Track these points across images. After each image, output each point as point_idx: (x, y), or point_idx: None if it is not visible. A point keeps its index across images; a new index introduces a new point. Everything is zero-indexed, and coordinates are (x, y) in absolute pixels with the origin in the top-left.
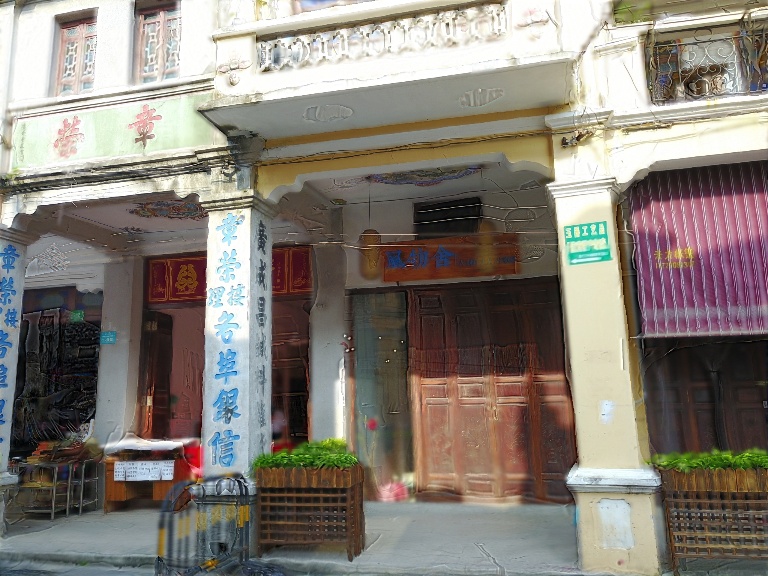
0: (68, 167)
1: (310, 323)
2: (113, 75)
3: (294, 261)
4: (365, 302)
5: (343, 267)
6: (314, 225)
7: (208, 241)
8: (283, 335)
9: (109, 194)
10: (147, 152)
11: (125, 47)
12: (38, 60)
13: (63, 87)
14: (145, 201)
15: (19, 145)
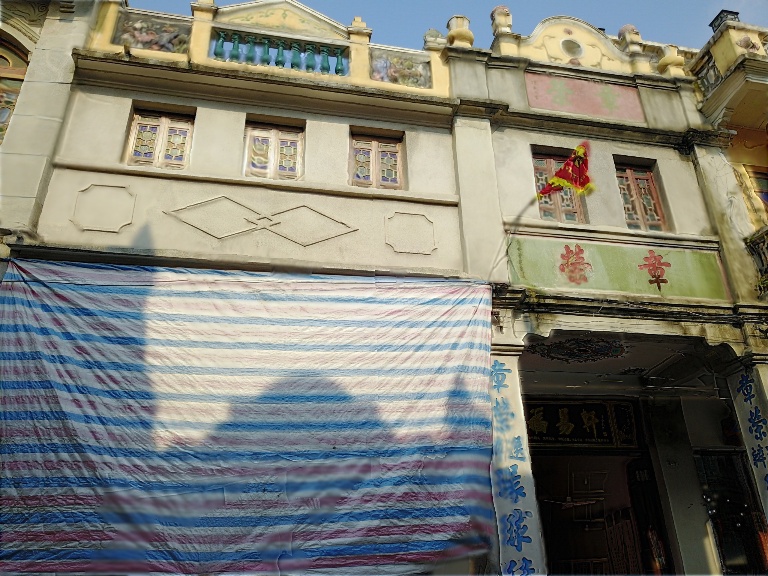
0: (600, 295)
1: (666, 481)
2: (607, 215)
3: (617, 415)
4: (710, 463)
5: (684, 427)
6: (690, 384)
7: (767, 392)
8: (595, 492)
9: (636, 330)
10: (666, 295)
11: (614, 192)
12: (520, 181)
13: (543, 212)
14: (652, 342)
15: (517, 261)
